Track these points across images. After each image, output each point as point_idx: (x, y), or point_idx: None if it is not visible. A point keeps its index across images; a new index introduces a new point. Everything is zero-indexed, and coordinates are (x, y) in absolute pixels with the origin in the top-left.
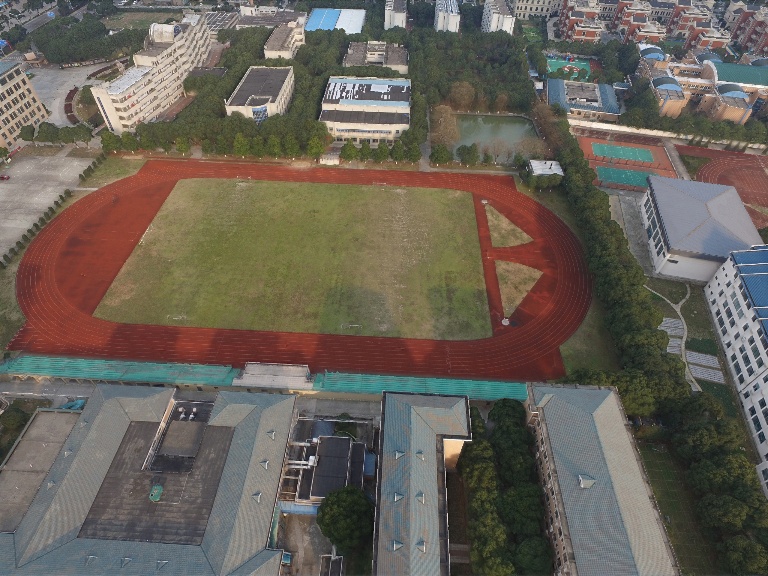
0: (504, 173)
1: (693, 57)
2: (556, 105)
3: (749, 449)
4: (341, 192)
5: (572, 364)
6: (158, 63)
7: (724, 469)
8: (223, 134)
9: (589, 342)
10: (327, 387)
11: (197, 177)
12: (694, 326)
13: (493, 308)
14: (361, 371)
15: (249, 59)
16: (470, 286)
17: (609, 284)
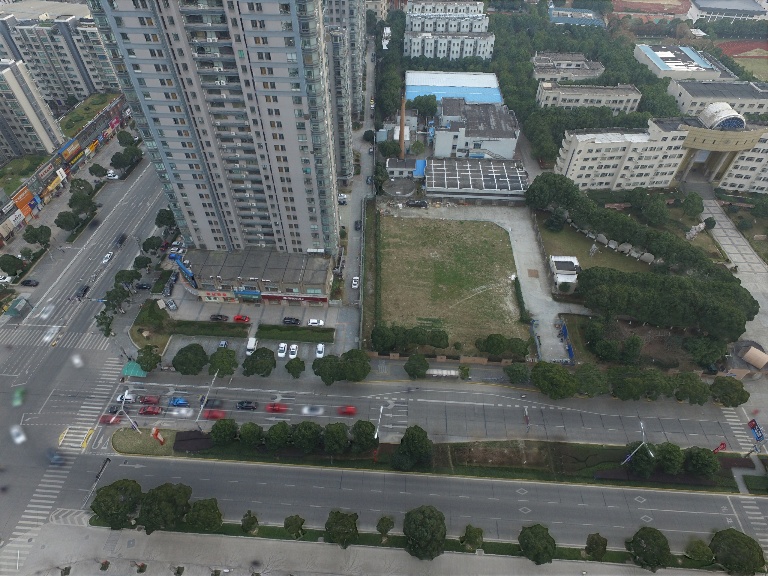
0: None
1: None
2: None
3: None
4: None
5: None
6: None
7: None
8: None
9: None
10: None
11: None
12: None
13: None
14: None
15: None
16: None
17: None
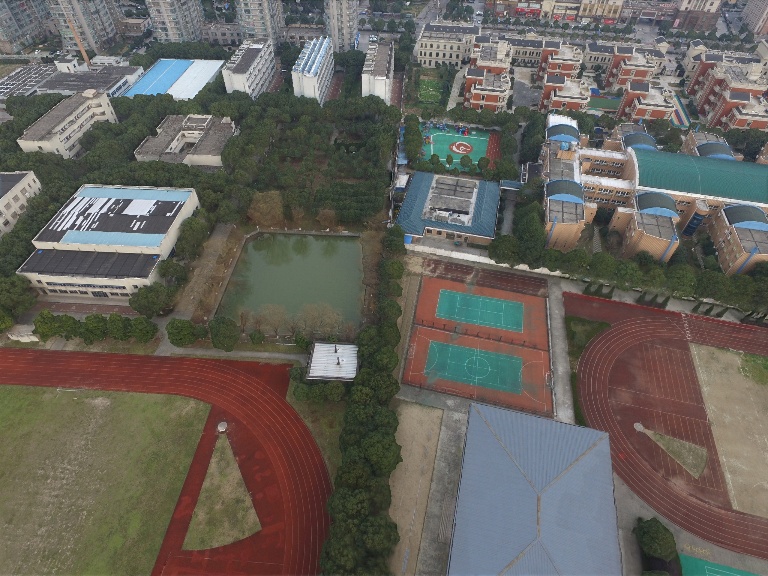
0: (282, 358)
1: (618, 137)
2: (395, 230)
3: None
4: (5, 406)
5: None
6: None
7: None
8: None
9: None
10: None
11: None
12: None
13: None
14: None
15: (4, 149)
16: None
17: None
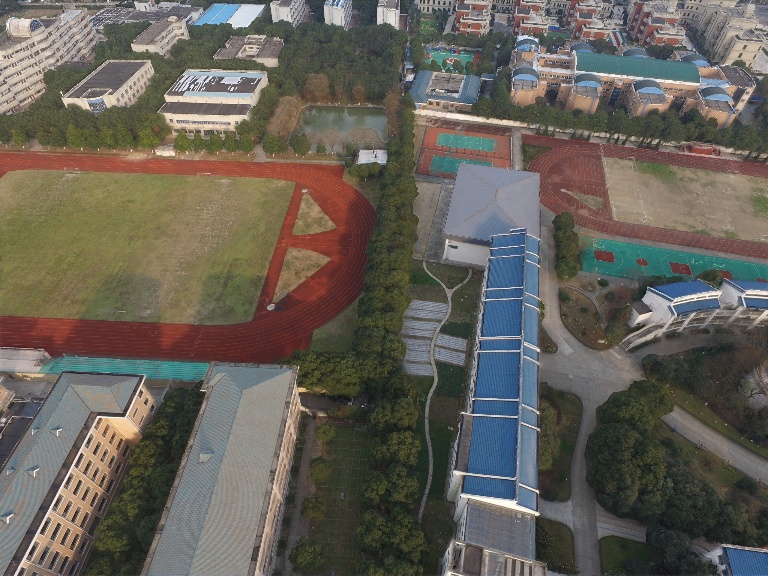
0: (337, 163)
1: (567, 48)
2: (407, 96)
3: (457, 429)
4: (165, 182)
5: (318, 347)
6: (12, 57)
7: (386, 446)
8: (59, 126)
9: (346, 326)
10: (54, 370)
11: (27, 169)
12: (458, 310)
13: (264, 294)
14: (104, 355)
15: (119, 53)
16: (251, 272)
17: (372, 269)
